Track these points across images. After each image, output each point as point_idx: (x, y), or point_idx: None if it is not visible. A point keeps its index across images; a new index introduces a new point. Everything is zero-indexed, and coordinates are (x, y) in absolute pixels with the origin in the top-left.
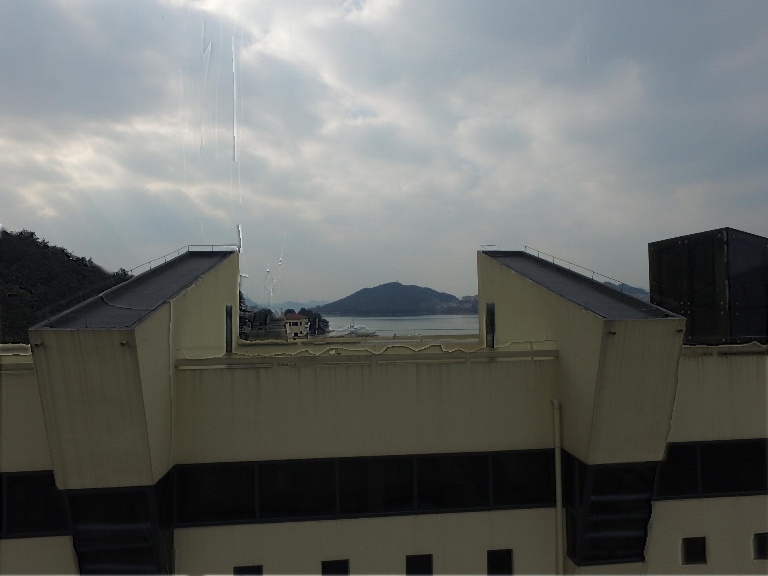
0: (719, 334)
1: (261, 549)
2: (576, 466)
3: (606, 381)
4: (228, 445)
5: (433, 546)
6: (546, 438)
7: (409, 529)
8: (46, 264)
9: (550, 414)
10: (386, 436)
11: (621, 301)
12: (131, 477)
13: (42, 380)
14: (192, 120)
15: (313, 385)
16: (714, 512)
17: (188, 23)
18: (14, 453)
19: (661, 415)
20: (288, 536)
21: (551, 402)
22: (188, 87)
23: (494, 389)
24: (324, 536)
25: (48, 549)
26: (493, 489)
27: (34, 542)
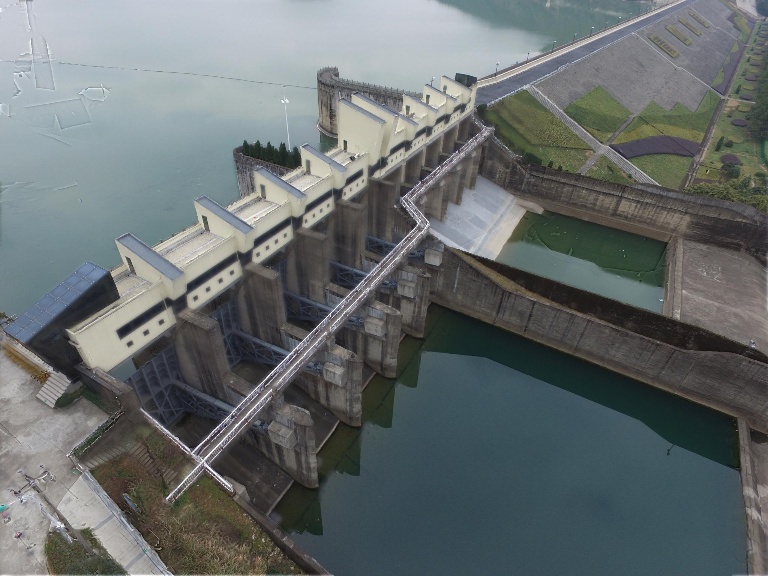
0: None
1: None
2: None
3: None
4: None
5: None
6: None
7: None
8: None
9: None
10: None
11: (466, 87)
12: None
13: None
14: None
15: None
16: None
17: None
18: None
19: None
20: None
21: None
22: None
23: None
24: None
25: None
26: None
27: None
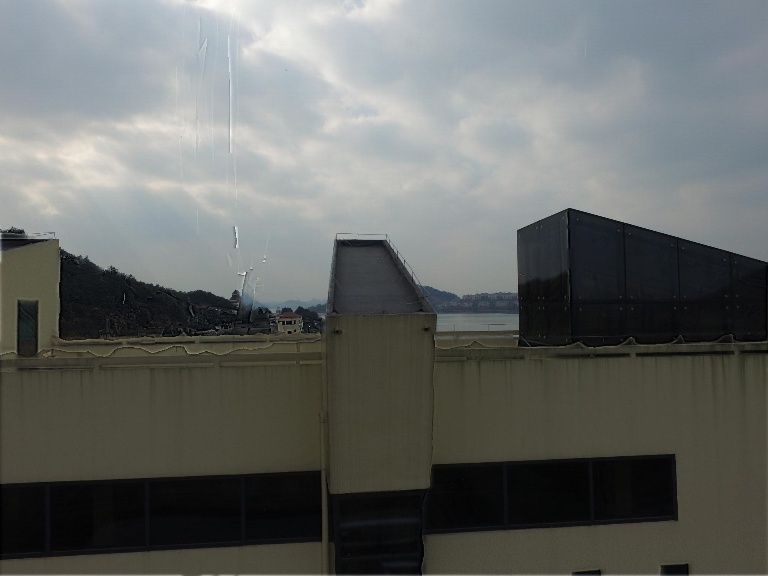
0: (564, 333)
1: None
2: None
3: (339, 392)
4: None
5: None
6: (312, 458)
7: (137, 568)
8: None
9: (317, 429)
10: (114, 456)
11: (406, 293)
12: None
13: None
14: (188, 118)
15: (18, 394)
16: (523, 546)
17: (184, 20)
18: None
19: (418, 433)
20: None
21: (318, 415)
22: (184, 85)
23: (249, 399)
24: None
25: None
26: (246, 520)
27: None
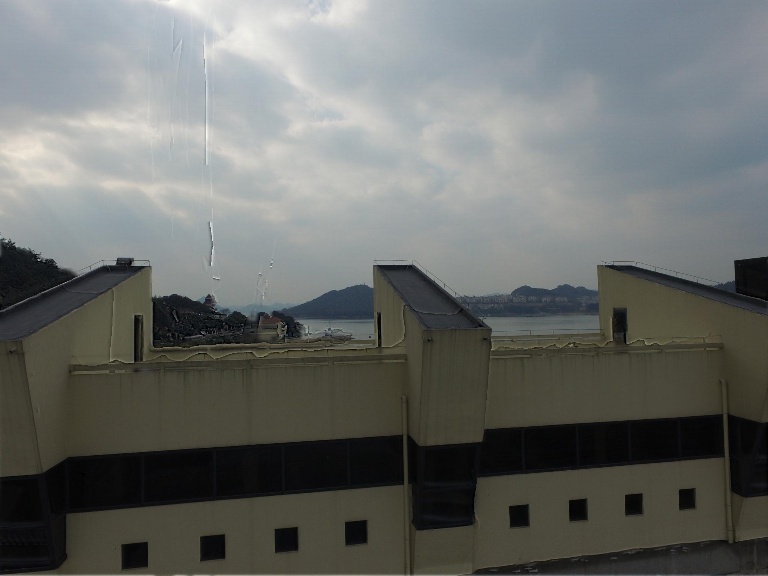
0: None
1: (527, 493)
2: (738, 427)
3: None
4: (503, 416)
5: (643, 488)
6: (716, 407)
7: (627, 475)
8: (15, 266)
9: (719, 389)
10: (608, 407)
11: (765, 307)
12: (469, 436)
13: (425, 366)
14: (161, 118)
15: (560, 370)
16: None
17: (157, 19)
18: (354, 424)
19: None
20: (544, 483)
21: (719, 381)
22: (156, 84)
23: (680, 372)
24: (569, 482)
25: (381, 496)
26: (681, 445)
27: (371, 491)
